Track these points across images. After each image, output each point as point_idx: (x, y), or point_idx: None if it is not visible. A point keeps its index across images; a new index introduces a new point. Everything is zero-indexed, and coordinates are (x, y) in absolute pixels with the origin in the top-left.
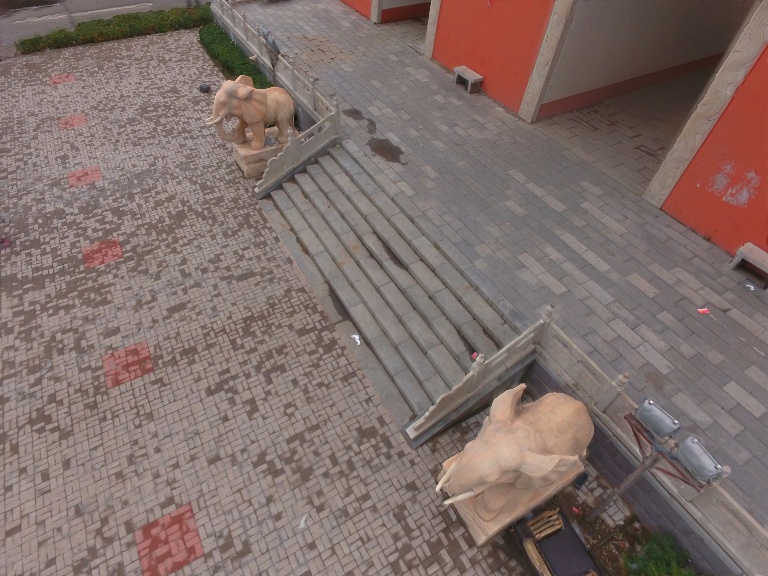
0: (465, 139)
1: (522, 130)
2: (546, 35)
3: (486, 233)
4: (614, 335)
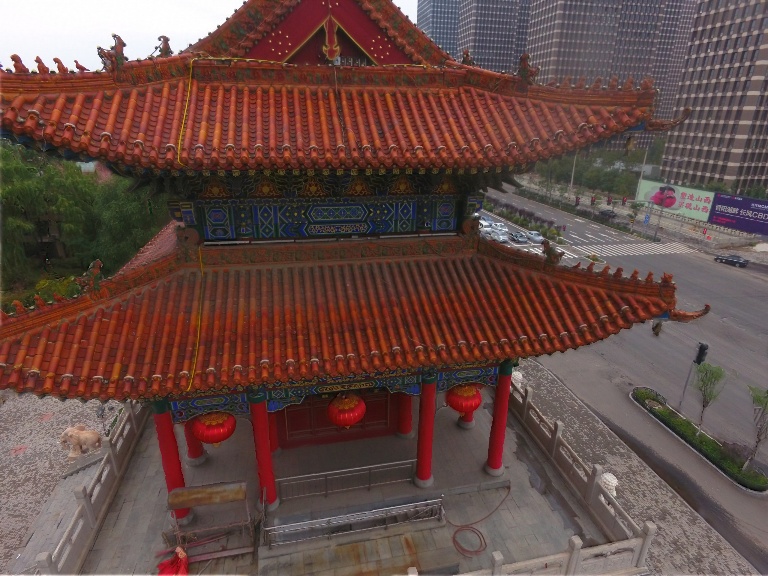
0: None
1: None
2: None
3: None
4: None
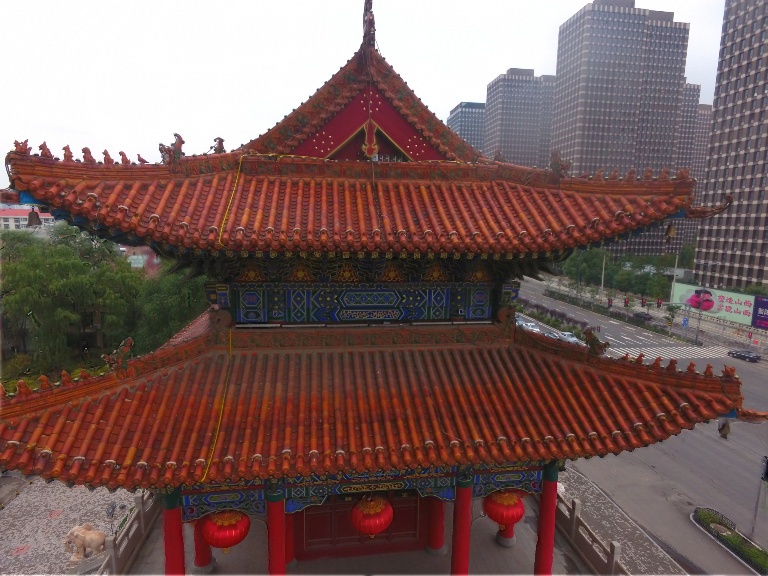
0: None
1: None
2: None
3: None
4: None
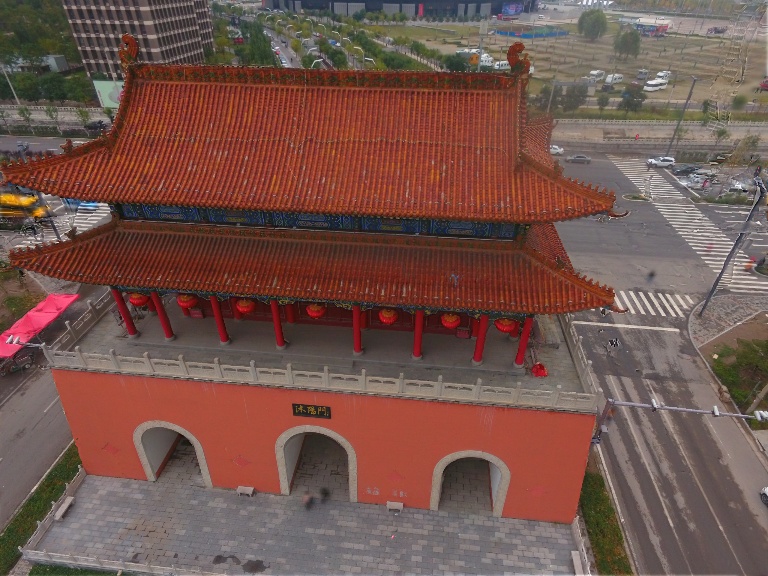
0: (276, 529)
1: (290, 502)
2: (279, 472)
3: (324, 570)
4: (382, 571)
